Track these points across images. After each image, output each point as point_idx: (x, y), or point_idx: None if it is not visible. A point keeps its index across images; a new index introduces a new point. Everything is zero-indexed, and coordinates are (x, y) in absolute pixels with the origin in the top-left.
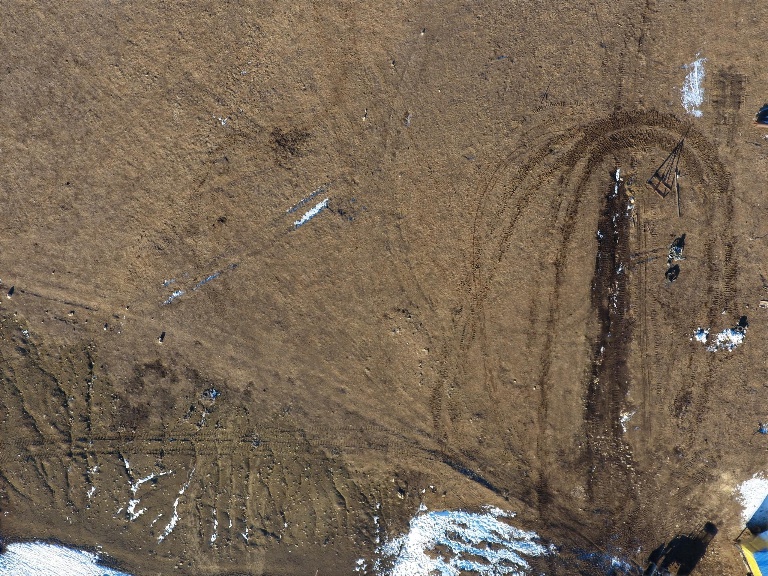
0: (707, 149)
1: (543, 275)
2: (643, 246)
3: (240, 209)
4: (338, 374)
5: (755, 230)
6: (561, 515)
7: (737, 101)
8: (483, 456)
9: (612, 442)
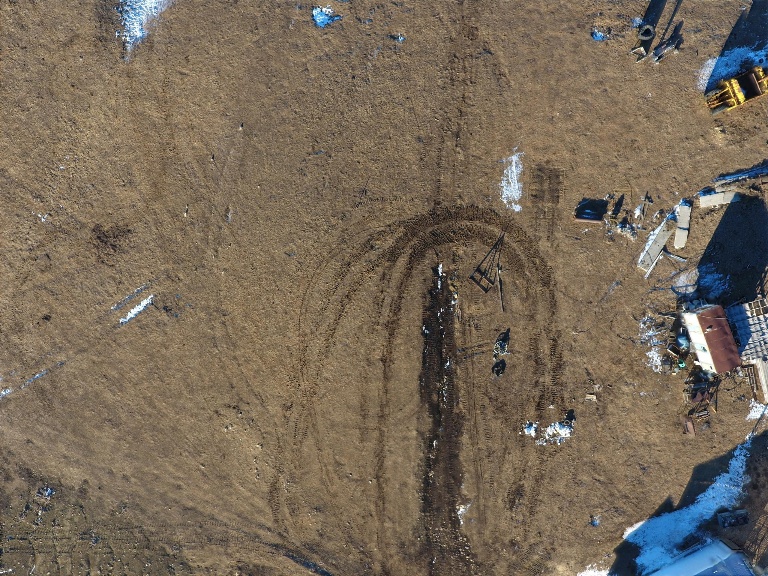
0: (528, 243)
1: (370, 371)
2: (468, 341)
3: (64, 307)
4: (173, 471)
5: (578, 324)
6: None
7: (556, 195)
8: (324, 549)
9: (450, 534)
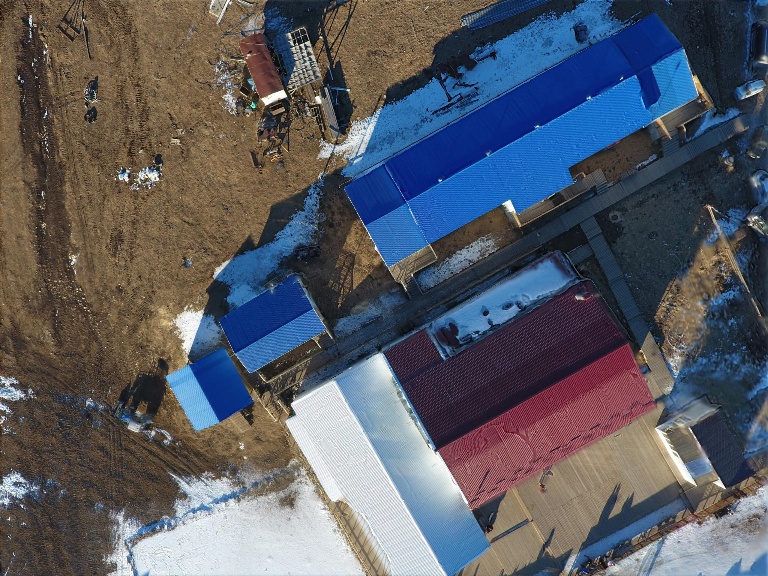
0: None
1: None
2: (61, 90)
3: None
4: None
5: (159, 70)
6: (36, 360)
7: None
8: None
9: (68, 285)
